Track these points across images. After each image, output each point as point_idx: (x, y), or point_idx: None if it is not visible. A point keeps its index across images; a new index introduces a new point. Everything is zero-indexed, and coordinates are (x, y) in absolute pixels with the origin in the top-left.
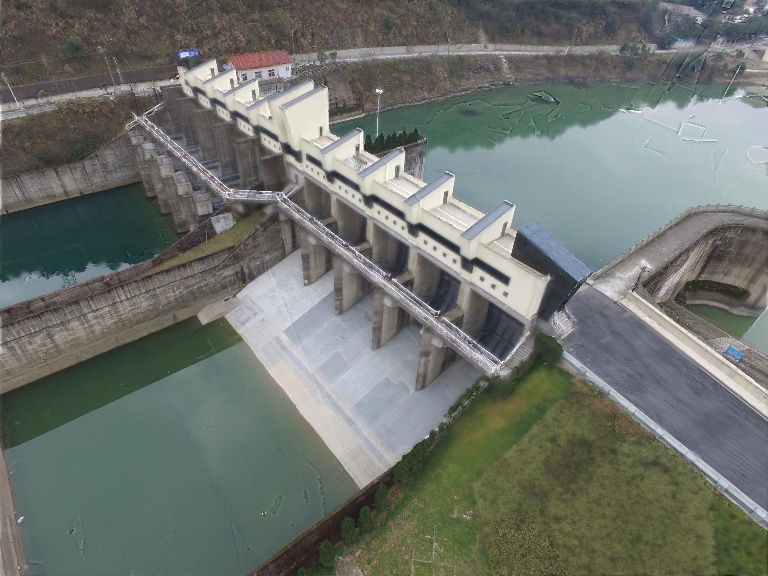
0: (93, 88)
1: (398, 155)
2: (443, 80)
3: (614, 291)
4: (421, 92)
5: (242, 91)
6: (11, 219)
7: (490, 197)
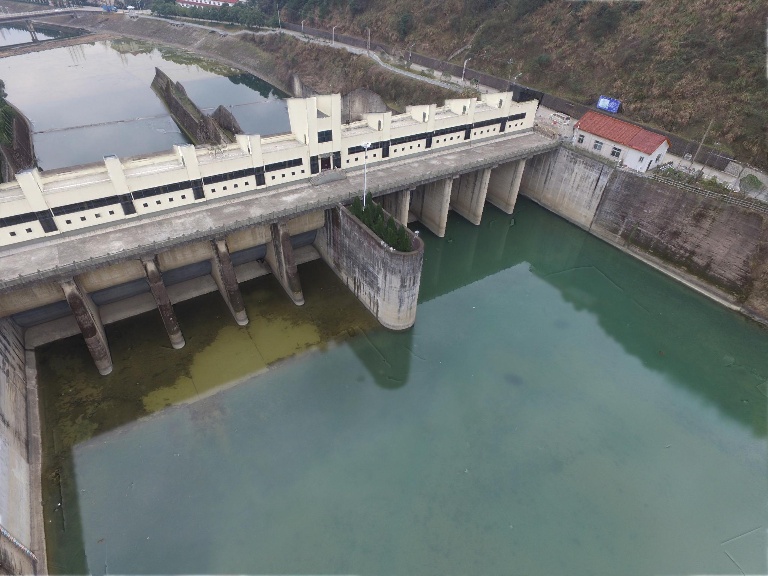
0: None
1: (181, 146)
2: None
3: None
4: None
5: (418, 109)
6: None
7: None
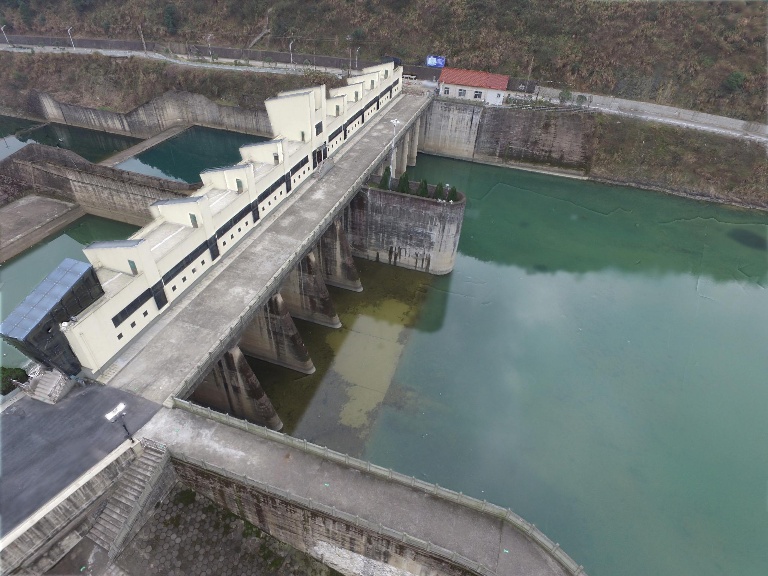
0: (352, 69)
1: None
2: (765, 183)
3: (157, 432)
4: (704, 184)
5: (346, 89)
6: (247, 138)
7: (528, 325)
